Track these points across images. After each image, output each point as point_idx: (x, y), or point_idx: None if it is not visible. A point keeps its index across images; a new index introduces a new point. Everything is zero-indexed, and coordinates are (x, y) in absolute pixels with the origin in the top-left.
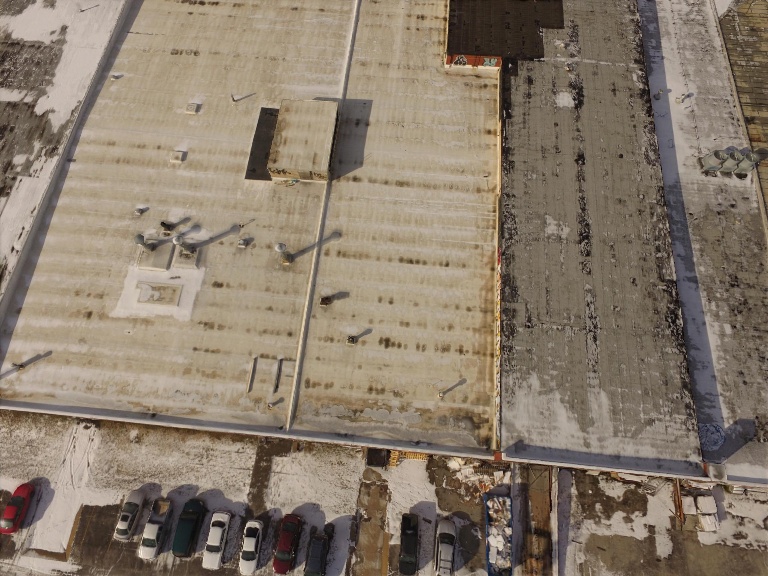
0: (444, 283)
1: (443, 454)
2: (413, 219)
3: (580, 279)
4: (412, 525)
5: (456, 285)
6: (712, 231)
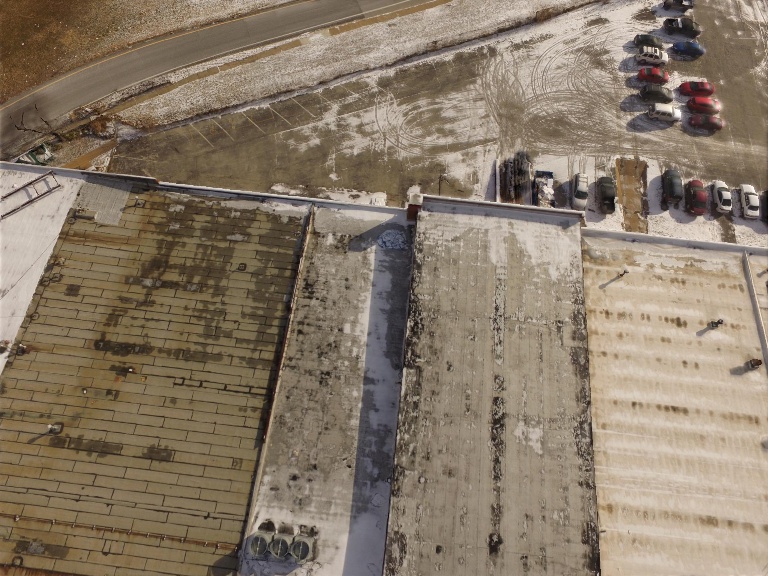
0: (634, 383)
1: (615, 230)
2: (684, 466)
3: (507, 370)
4: (606, 206)
5: (621, 380)
6: (330, 442)
